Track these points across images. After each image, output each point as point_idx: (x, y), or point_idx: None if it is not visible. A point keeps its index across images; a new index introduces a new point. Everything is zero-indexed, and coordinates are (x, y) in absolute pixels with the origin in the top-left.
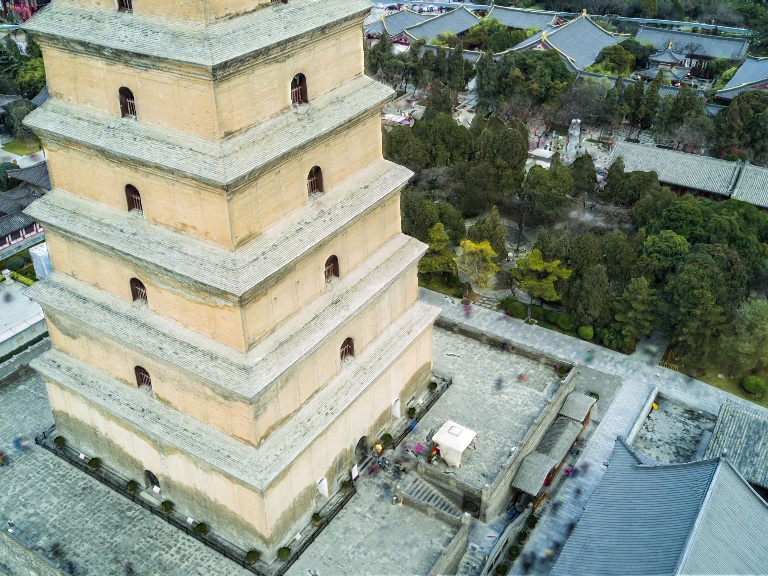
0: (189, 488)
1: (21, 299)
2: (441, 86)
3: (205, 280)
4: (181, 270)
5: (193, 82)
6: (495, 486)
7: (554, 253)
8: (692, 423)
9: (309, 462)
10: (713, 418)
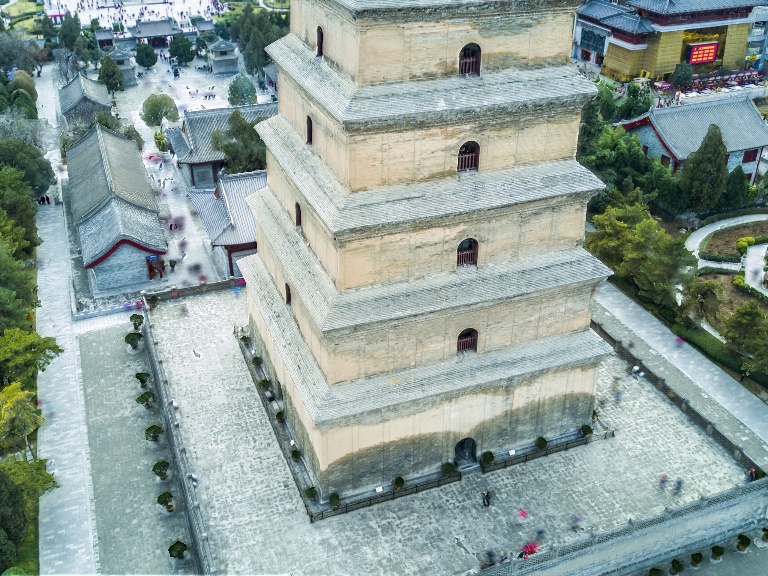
0: None
1: None
2: None
3: None
4: None
5: None
6: None
7: None
8: (93, 305)
9: None
10: None
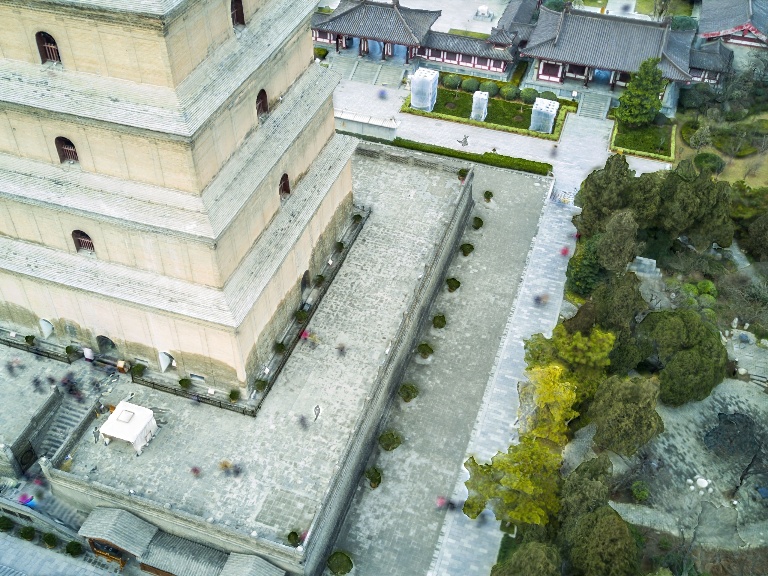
0: None
1: (387, 102)
2: None
3: None
4: None
5: None
6: (67, 478)
7: (568, 486)
8: None
9: (22, 289)
10: None
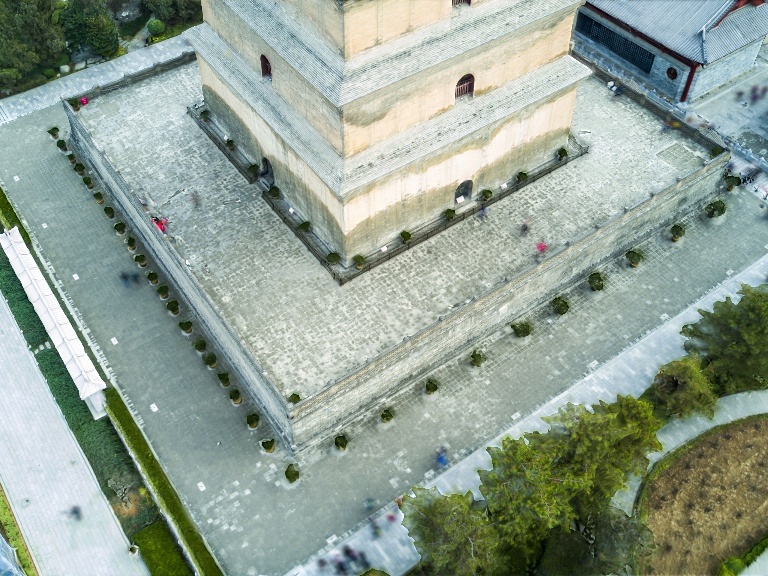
0: (506, 155)
1: None
2: None
3: None
4: None
5: None
6: None
7: None
8: None
9: None
10: None
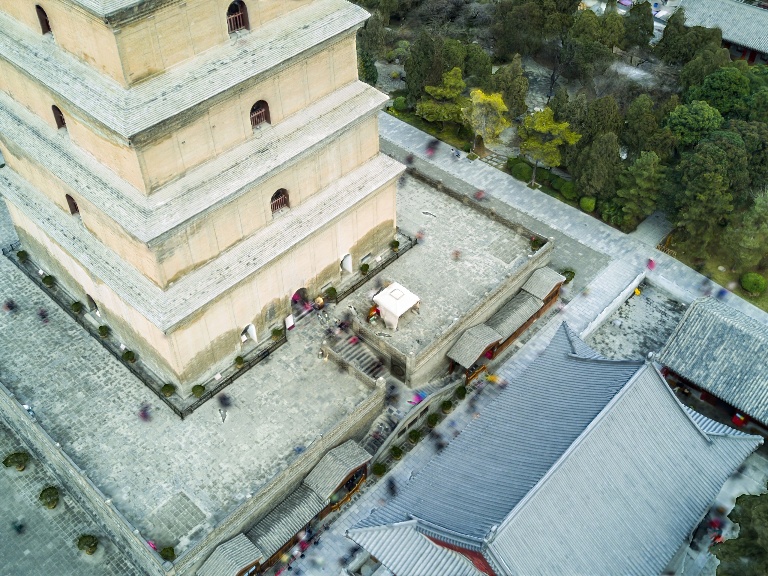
0: (118, 317)
1: None
2: None
3: (99, 117)
4: (80, 104)
5: None
6: (424, 354)
7: (567, 114)
8: (672, 314)
9: (229, 308)
10: None
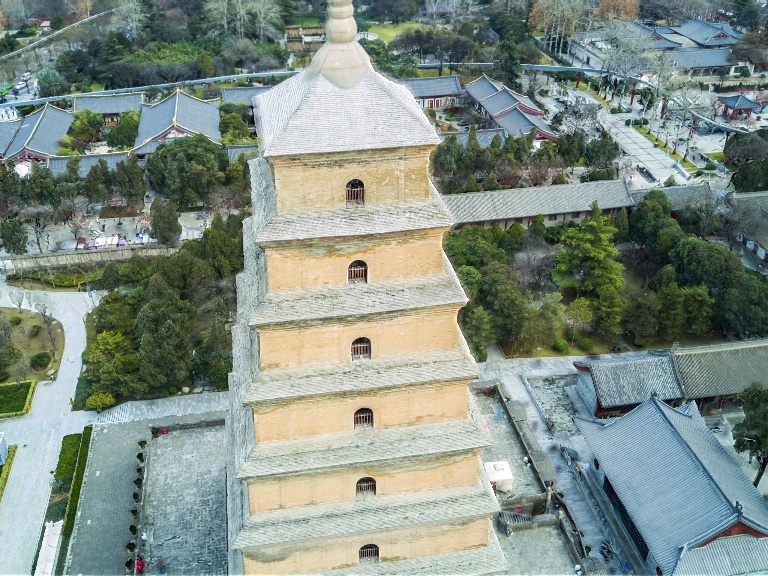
0: None
1: None
2: (162, 201)
3: (460, 447)
4: (434, 450)
5: (439, 315)
6: None
7: None
8: (554, 386)
9: None
10: (560, 377)
